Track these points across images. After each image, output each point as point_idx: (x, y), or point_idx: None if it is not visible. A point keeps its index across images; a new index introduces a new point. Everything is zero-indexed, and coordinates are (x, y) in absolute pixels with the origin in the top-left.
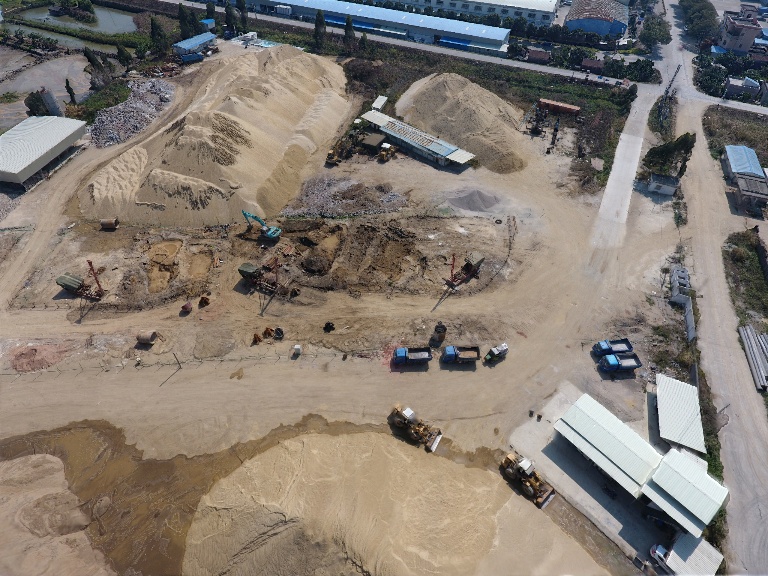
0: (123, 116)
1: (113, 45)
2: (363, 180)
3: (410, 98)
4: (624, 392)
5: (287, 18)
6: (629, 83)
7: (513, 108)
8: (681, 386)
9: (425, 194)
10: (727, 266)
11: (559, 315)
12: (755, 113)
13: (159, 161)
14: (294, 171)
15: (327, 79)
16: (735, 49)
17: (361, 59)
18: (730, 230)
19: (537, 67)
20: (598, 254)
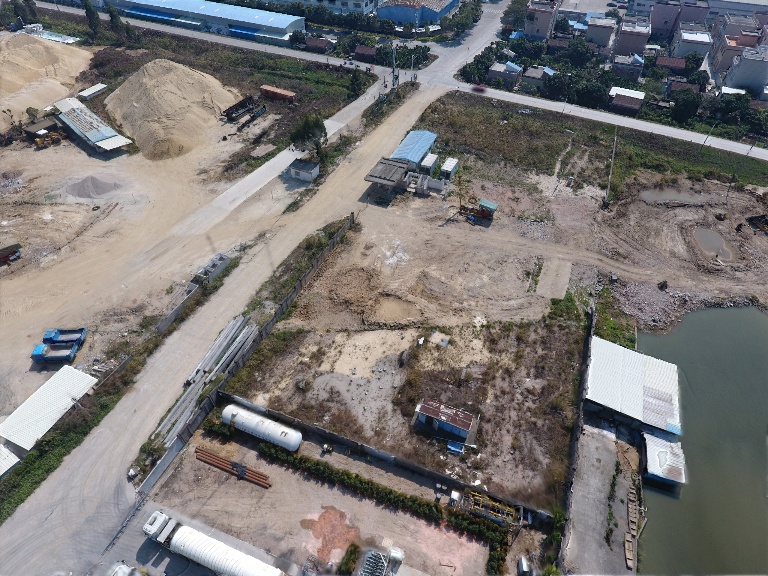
0: None
1: None
2: None
3: None
4: (37, 384)
5: (99, 10)
6: (384, 69)
7: (233, 95)
8: (78, 378)
9: (49, 181)
10: (293, 254)
11: (56, 303)
12: (490, 98)
13: None
14: None
15: (54, 67)
16: (534, 34)
17: (130, 49)
18: (337, 217)
19: (302, 54)
20: (167, 241)
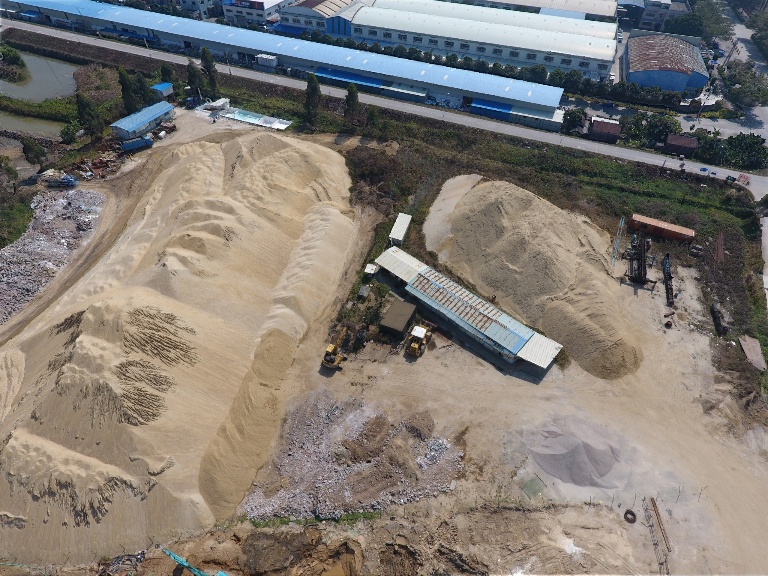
0: (7, 273)
1: (37, 118)
2: (384, 406)
3: (446, 222)
4: None
5: (271, 71)
6: None
7: (594, 229)
8: None
9: (491, 439)
10: None
11: None
12: None
13: (29, 408)
14: (269, 394)
15: (323, 186)
16: None
17: (369, 139)
18: None
19: (609, 149)
20: None
